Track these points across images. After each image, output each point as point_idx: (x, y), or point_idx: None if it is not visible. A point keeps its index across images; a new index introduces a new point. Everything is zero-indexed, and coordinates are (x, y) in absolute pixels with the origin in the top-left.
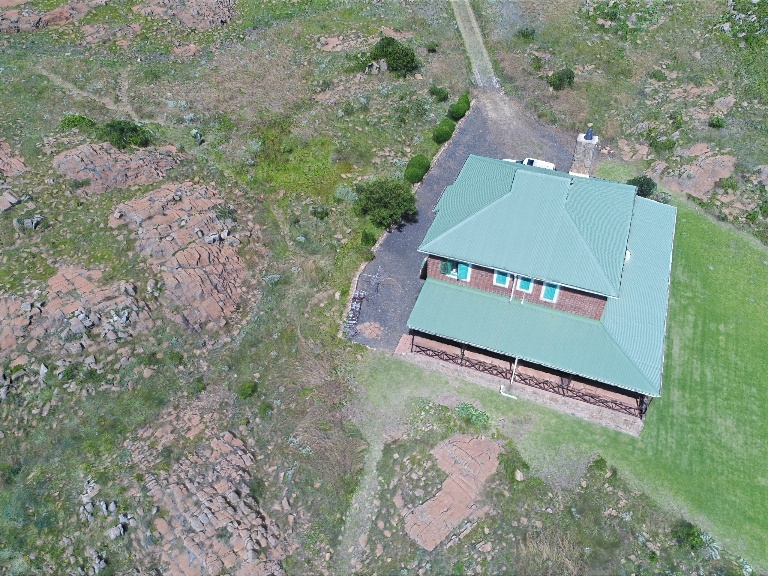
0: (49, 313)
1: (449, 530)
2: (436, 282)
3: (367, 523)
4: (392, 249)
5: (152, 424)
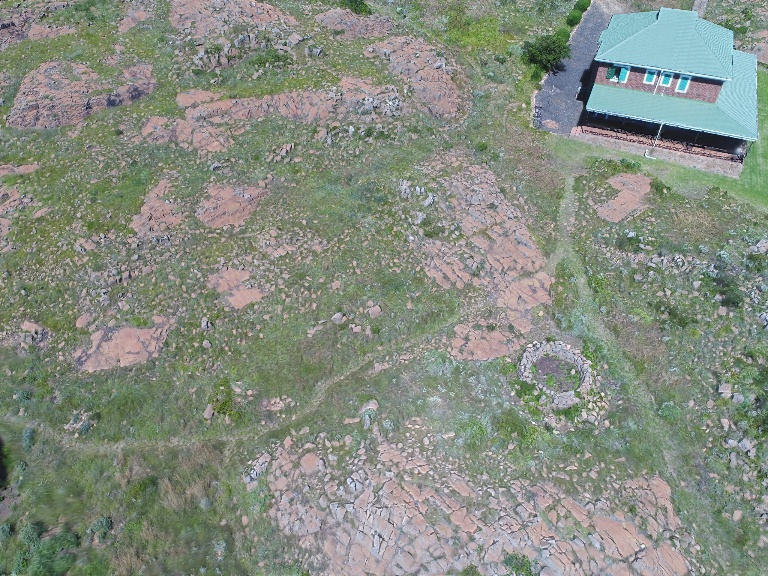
0: (346, 100)
1: (626, 214)
2: (601, 86)
3: (573, 213)
4: None
5: (427, 160)
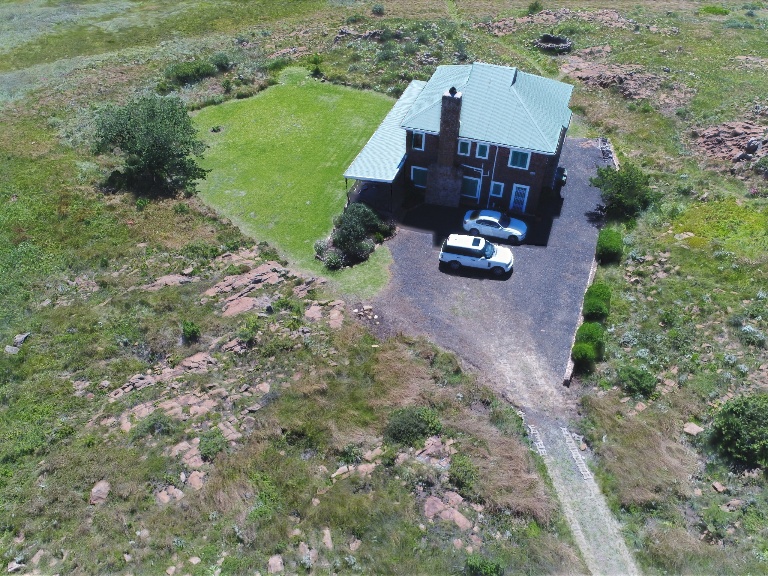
0: None
1: None
2: None
3: None
4: (598, 191)
5: None
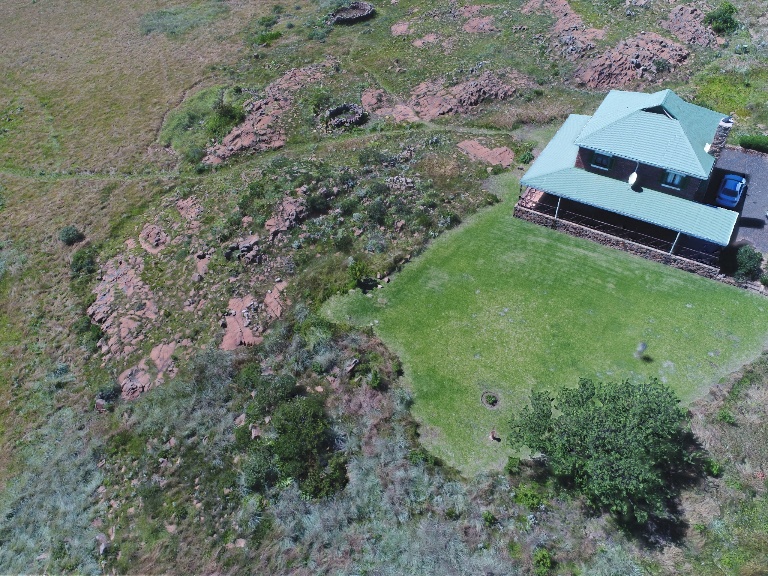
0: None
1: None
2: None
3: None
4: None
5: (519, 73)
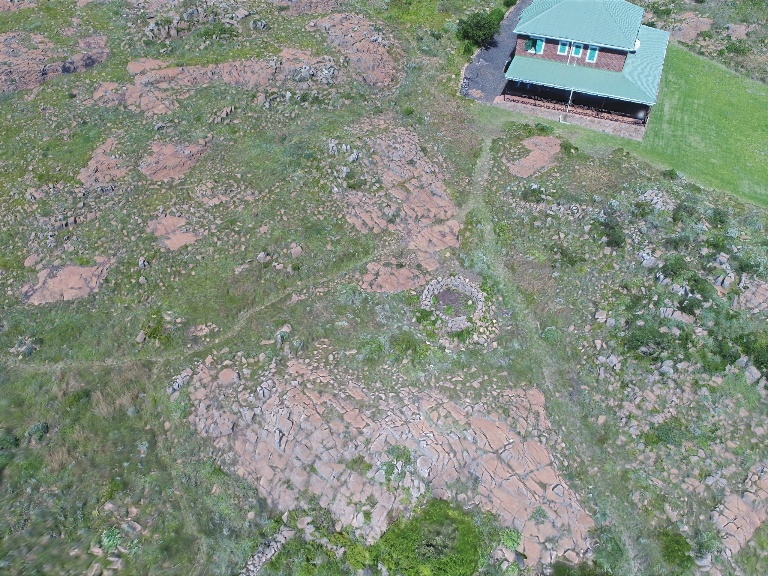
0: (285, 68)
1: (535, 170)
2: (521, 57)
3: (487, 170)
4: (484, 59)
5: (357, 123)
